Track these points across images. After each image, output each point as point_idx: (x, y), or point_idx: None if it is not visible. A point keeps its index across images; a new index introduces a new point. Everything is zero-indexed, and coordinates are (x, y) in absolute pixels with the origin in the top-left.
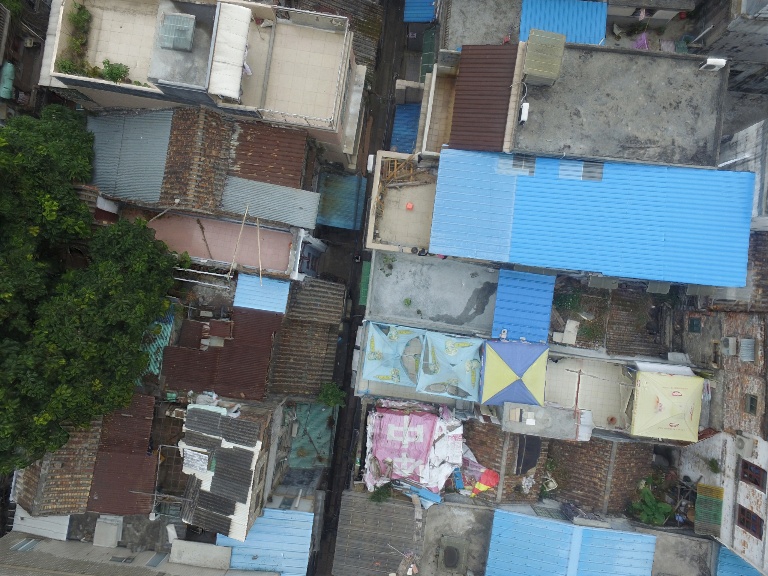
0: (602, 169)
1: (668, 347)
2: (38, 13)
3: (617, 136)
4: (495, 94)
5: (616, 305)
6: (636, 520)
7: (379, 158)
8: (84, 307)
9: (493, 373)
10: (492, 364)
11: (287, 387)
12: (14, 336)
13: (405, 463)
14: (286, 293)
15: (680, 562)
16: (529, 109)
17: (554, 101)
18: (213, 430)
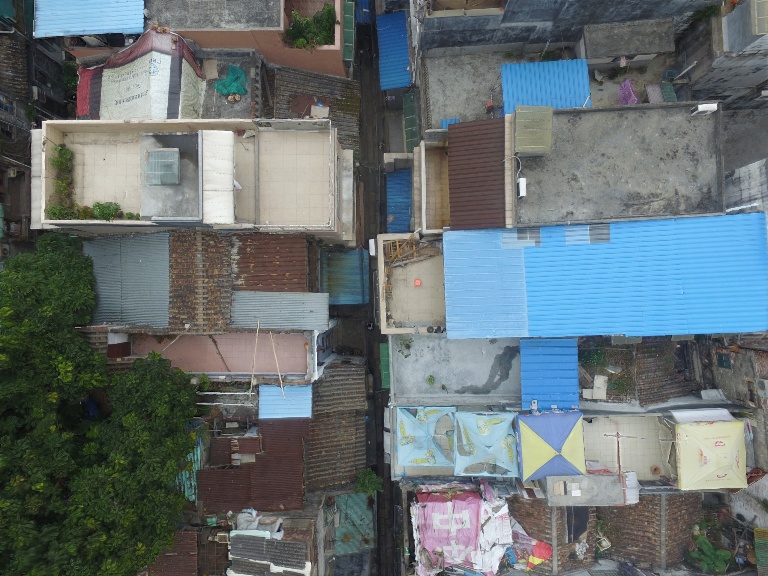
0: (609, 230)
1: (699, 382)
2: (17, 141)
3: (619, 195)
4: (489, 170)
5: (641, 354)
6: (697, 571)
7: (380, 242)
8: (116, 476)
9: (530, 449)
10: (528, 440)
11: (323, 481)
12: (51, 519)
13: (455, 551)
14: (309, 396)
15: None
16: (526, 181)
17: (550, 169)
18: (259, 555)
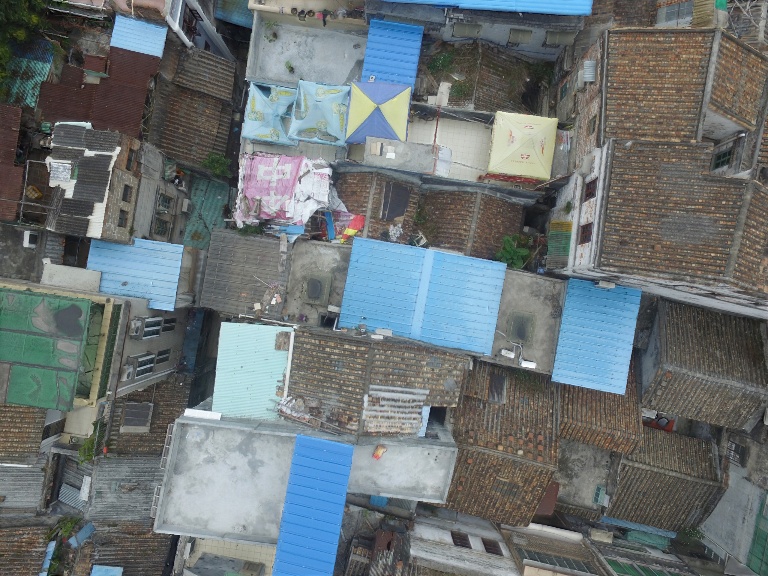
0: None
1: None
2: None
3: None
4: None
5: (487, 67)
6: None
7: None
8: None
9: (356, 108)
10: (356, 101)
11: (175, 156)
12: None
13: (273, 200)
14: (163, 38)
15: (534, 301)
16: None
17: None
18: (77, 142)
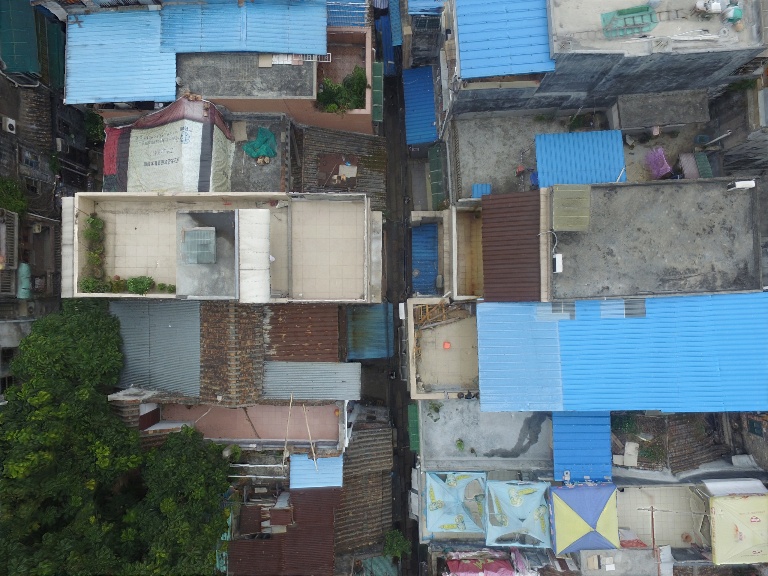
0: (644, 304)
1: (729, 446)
2: (41, 195)
3: (655, 270)
4: (523, 243)
5: (673, 421)
6: None
7: (410, 306)
8: (157, 571)
9: (564, 523)
10: (561, 513)
11: (350, 543)
12: None
13: None
14: (340, 465)
15: None
16: None
17: (585, 244)
18: None
